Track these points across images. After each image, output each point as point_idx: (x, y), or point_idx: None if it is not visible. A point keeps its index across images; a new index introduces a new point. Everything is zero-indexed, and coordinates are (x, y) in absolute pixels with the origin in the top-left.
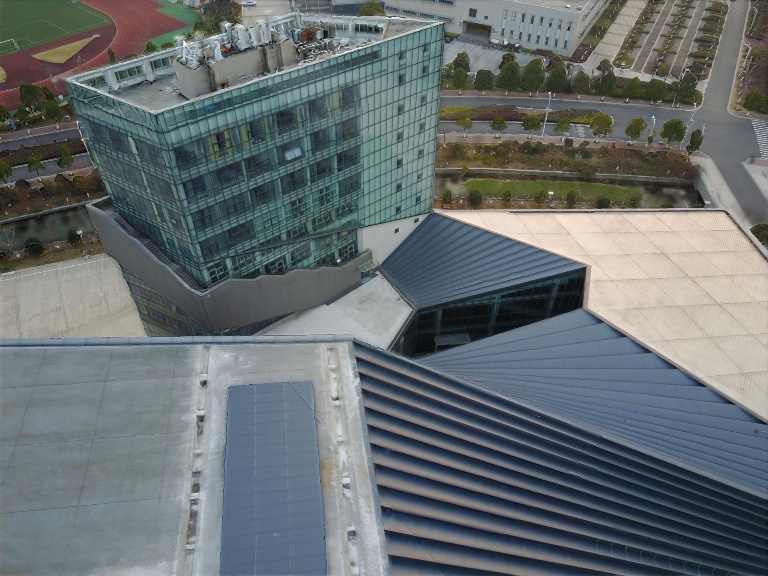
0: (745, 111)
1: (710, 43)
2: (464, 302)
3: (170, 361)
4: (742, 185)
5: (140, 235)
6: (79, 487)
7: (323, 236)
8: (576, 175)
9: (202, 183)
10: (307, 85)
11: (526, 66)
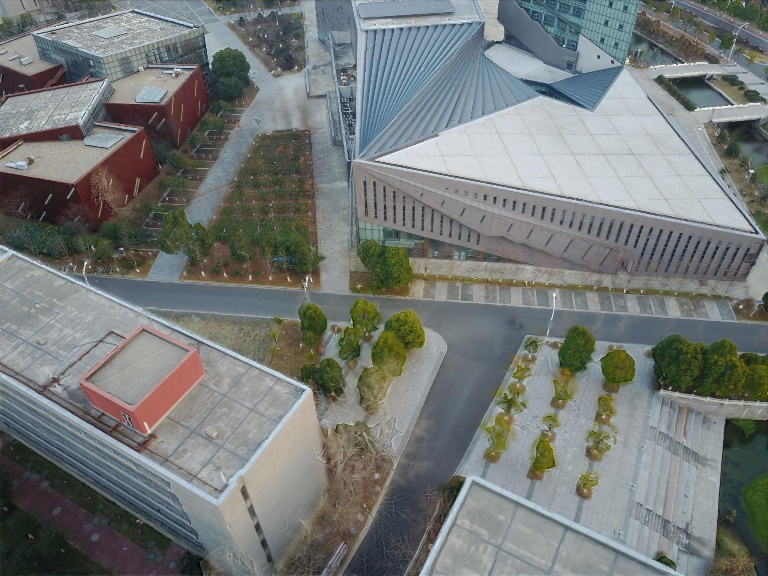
0: None
1: None
2: None
3: None
4: None
5: None
6: None
7: None
8: None
9: None
10: None
11: None
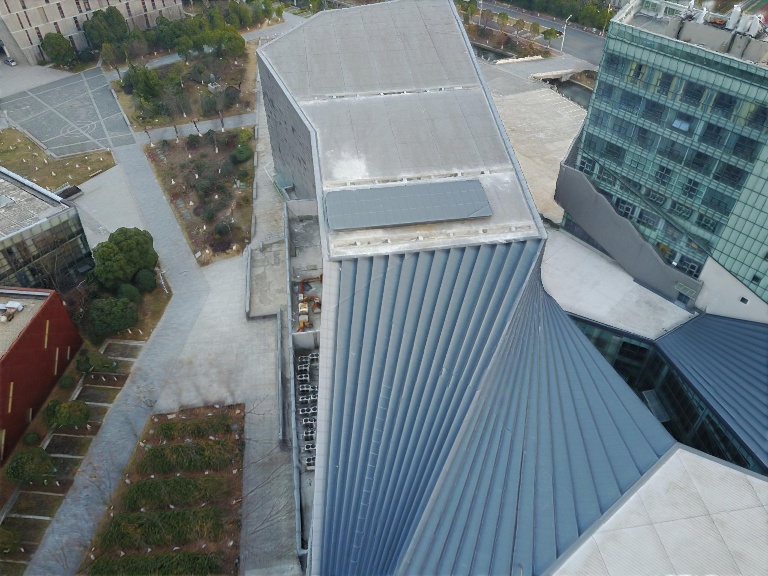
0: None
1: None
2: (683, 381)
3: (495, 157)
4: None
5: None
6: (406, 142)
7: None
8: None
9: (610, 91)
10: (724, 76)
11: None
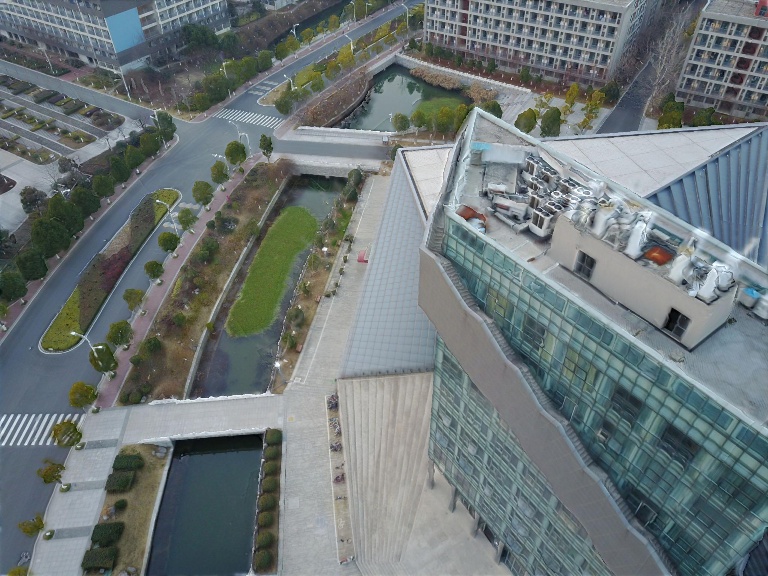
0: (197, 115)
1: (54, 96)
2: None
3: None
4: (313, 148)
5: None
6: None
7: None
8: (253, 239)
9: None
10: None
11: (53, 213)
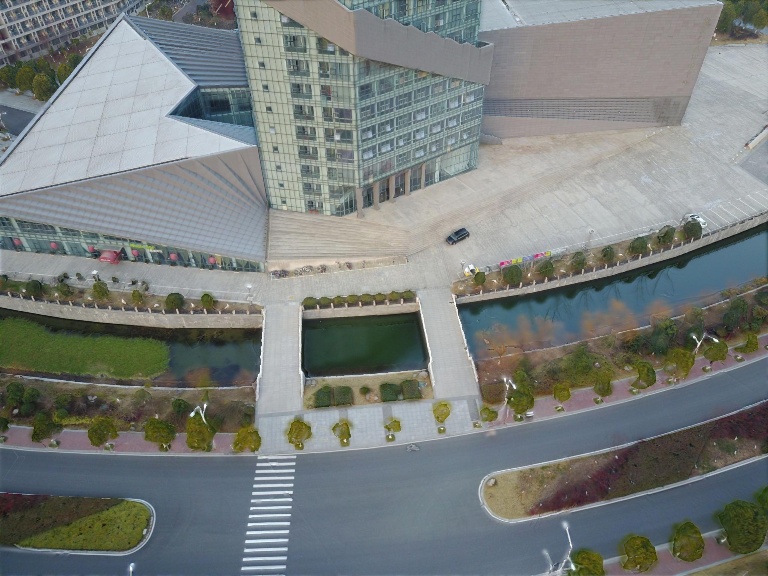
0: None
1: None
2: None
3: None
4: None
5: None
6: None
7: None
8: None
9: None
10: None
11: None
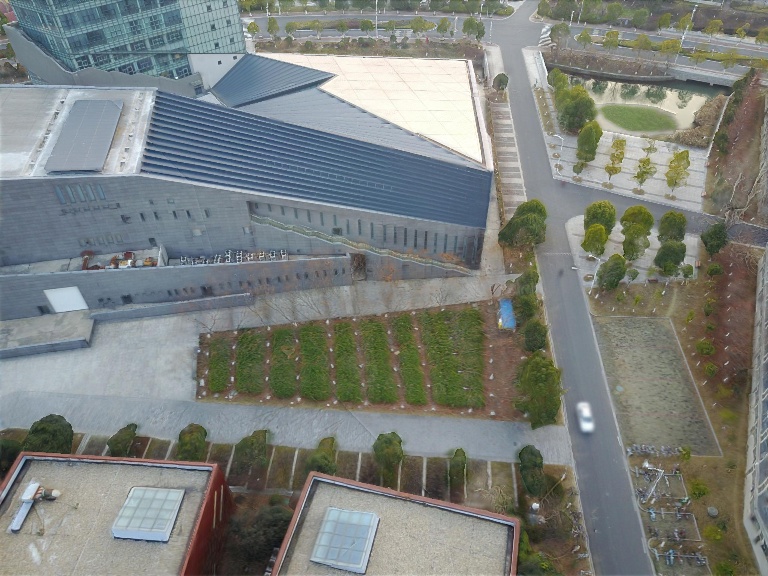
0: None
1: None
2: None
3: (45, 94)
4: (513, 61)
5: (35, 41)
6: None
7: (160, 55)
8: None
9: None
10: None
11: None
